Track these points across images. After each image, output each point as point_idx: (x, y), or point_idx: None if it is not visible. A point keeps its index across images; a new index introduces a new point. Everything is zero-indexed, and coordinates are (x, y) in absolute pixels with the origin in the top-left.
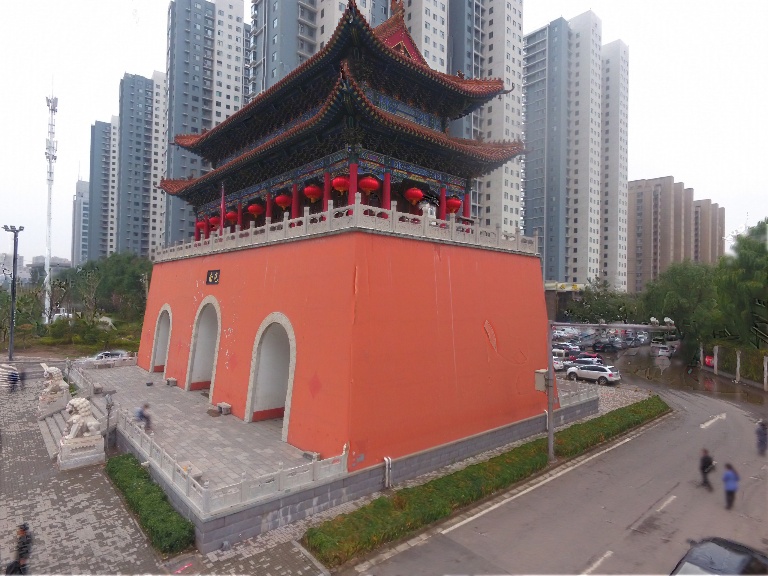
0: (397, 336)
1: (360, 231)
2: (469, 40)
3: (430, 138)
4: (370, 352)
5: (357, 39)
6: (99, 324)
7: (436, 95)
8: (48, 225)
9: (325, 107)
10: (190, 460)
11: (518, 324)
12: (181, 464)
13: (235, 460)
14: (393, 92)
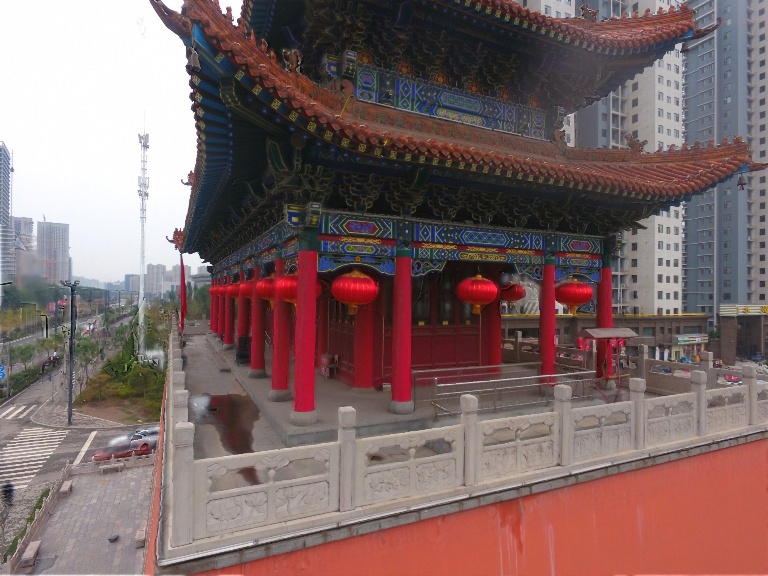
0: None
1: (181, 574)
2: (605, 2)
3: (501, 169)
4: None
5: None
6: (161, 381)
7: (530, 63)
8: (141, 263)
9: (197, 125)
10: None
11: None
12: None
13: None
14: (427, 68)
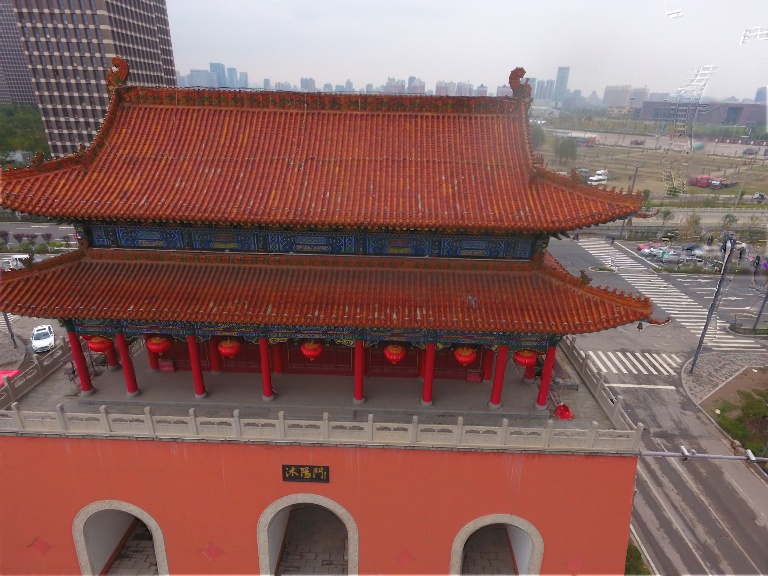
0: None
1: None
2: None
3: None
4: None
5: None
6: None
7: None
8: None
9: None
10: None
11: None
12: None
13: None
14: None
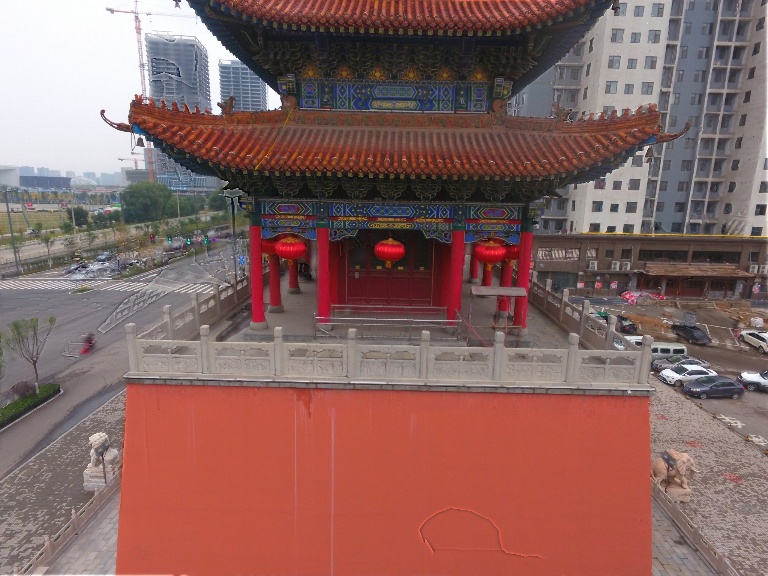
0: (204, 530)
1: (132, 382)
2: None
3: (353, 172)
4: (151, 548)
5: (230, 18)
6: None
7: (455, 46)
8: None
9: None
10: (85, 551)
11: (534, 530)
12: (35, 571)
13: (102, 574)
14: (359, 70)
